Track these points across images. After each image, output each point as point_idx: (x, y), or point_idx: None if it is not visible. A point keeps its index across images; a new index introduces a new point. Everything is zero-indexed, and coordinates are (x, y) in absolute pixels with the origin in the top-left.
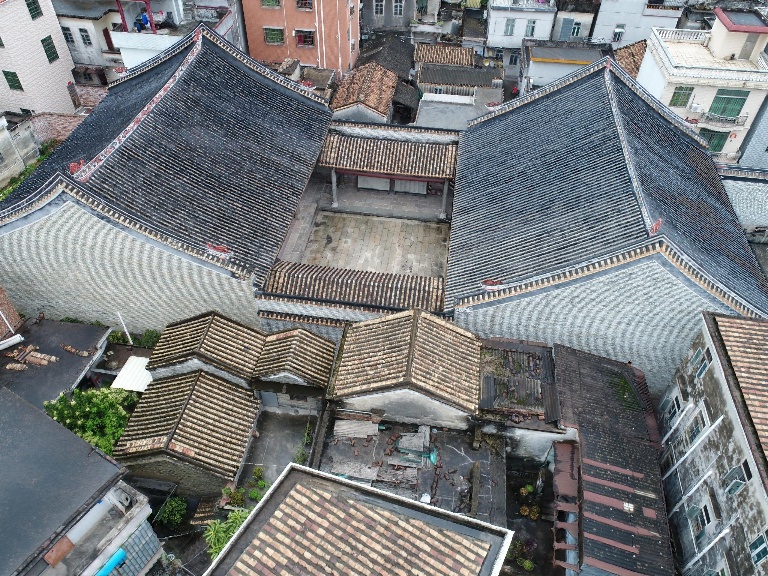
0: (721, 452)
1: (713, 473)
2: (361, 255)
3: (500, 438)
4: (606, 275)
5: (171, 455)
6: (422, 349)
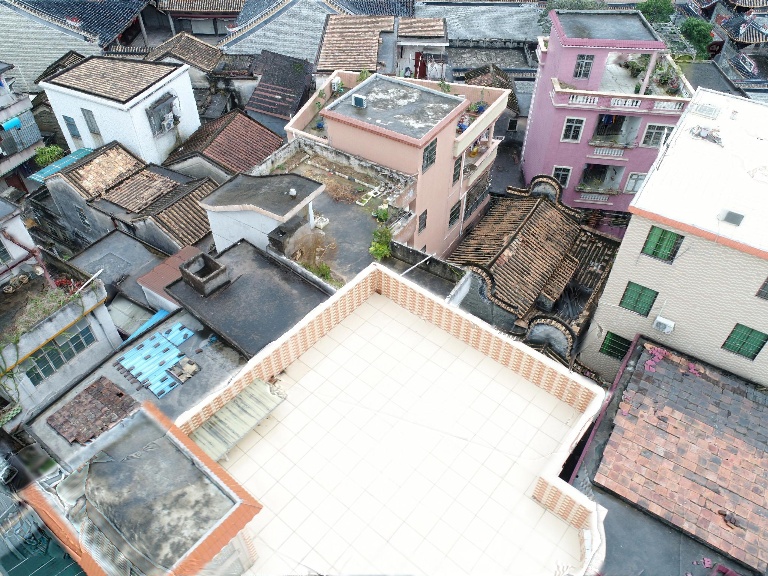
0: None
1: None
2: None
3: (229, 91)
4: (287, 10)
5: (47, 105)
6: None
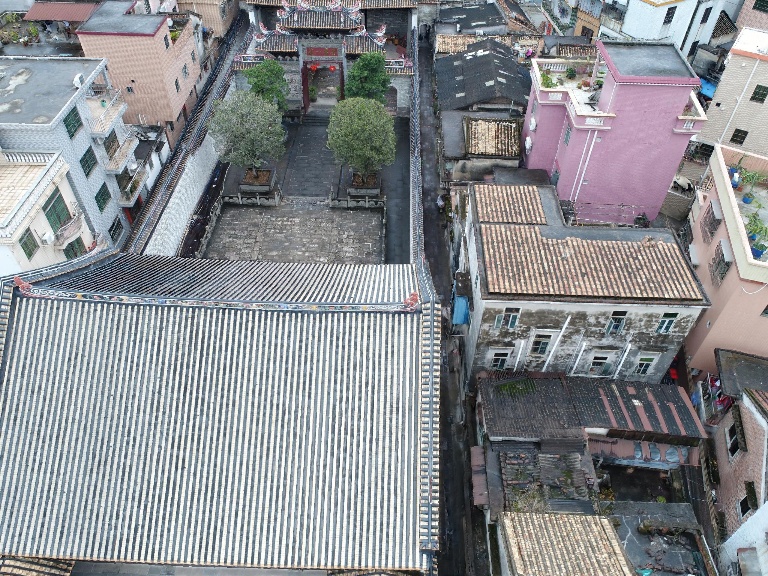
0: (584, 329)
1: (587, 342)
2: None
3: None
4: None
5: None
6: (571, 572)
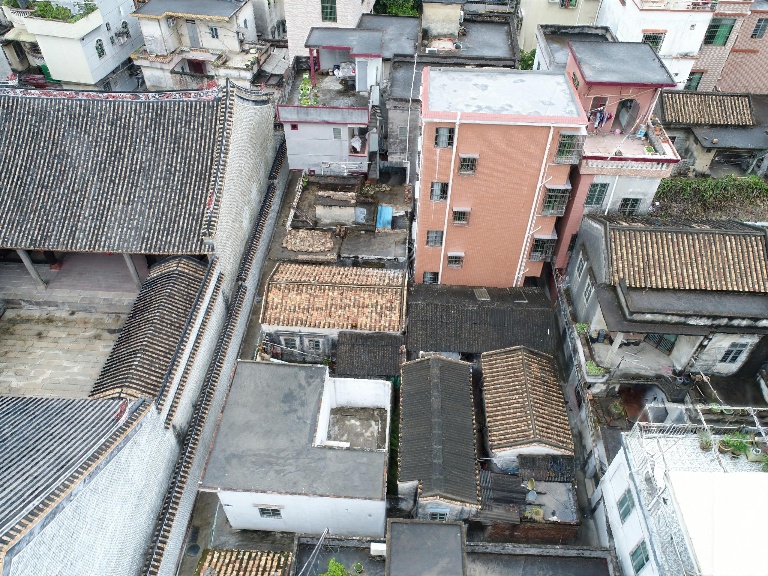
0: None
1: None
2: (77, 362)
3: None
4: None
5: None
6: None
